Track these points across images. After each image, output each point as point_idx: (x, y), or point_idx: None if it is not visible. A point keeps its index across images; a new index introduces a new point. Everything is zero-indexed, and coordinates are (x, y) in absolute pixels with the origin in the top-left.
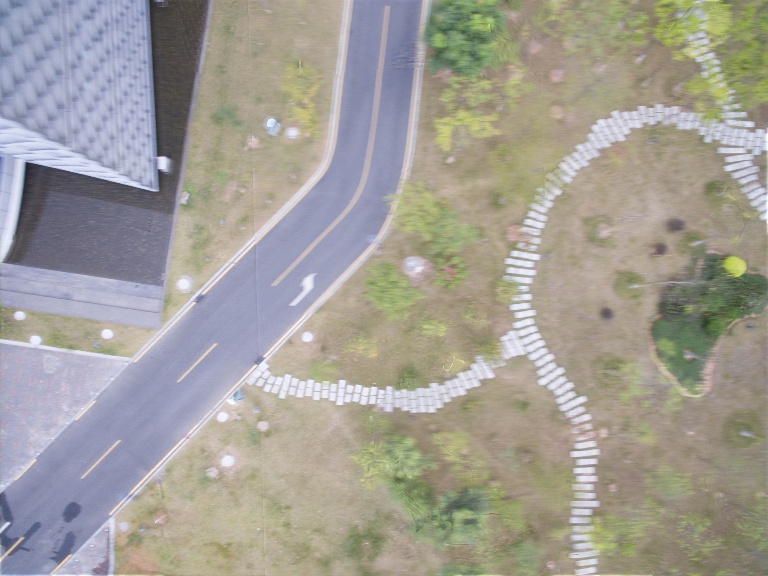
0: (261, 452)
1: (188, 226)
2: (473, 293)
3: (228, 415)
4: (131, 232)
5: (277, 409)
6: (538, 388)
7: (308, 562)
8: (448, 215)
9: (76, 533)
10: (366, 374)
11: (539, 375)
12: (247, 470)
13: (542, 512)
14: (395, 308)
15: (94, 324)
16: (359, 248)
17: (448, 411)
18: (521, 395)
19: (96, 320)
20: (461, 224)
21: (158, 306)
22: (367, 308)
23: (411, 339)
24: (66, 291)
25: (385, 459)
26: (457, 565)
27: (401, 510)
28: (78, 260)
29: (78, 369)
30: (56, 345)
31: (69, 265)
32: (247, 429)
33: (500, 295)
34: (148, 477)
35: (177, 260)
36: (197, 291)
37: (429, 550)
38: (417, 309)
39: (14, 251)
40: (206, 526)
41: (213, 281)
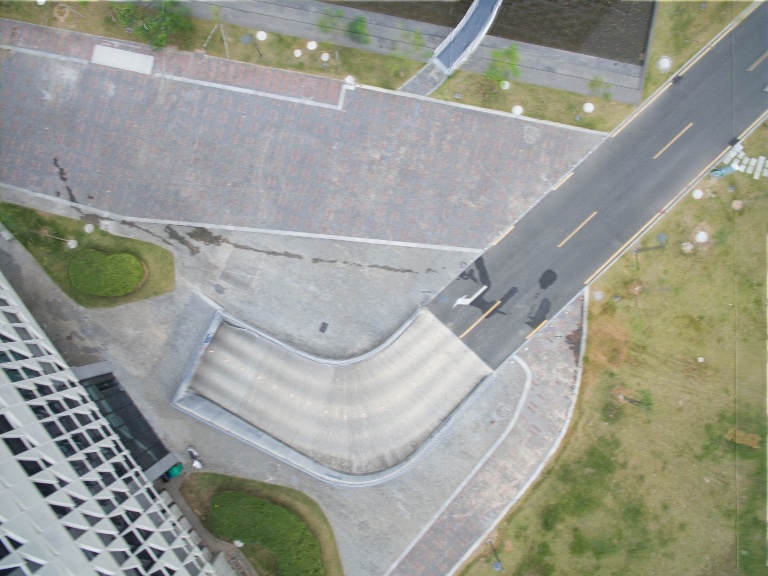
0: (735, 230)
1: (669, 8)
2: None
3: (703, 193)
4: (611, 12)
5: (751, 189)
6: None
7: None
8: None
9: (551, 300)
10: None
11: None
12: (721, 246)
13: None
14: None
15: (577, 97)
16: None
17: None
18: None
19: (579, 93)
20: None
21: (638, 83)
22: None
23: None
24: (549, 64)
25: None
26: None
27: None
28: (558, 36)
29: (557, 141)
30: (537, 116)
31: (549, 41)
32: (722, 207)
33: None
34: (624, 248)
35: (658, 40)
36: (675, 71)
37: None
38: None
39: (496, 24)
40: (679, 299)
41: (690, 63)
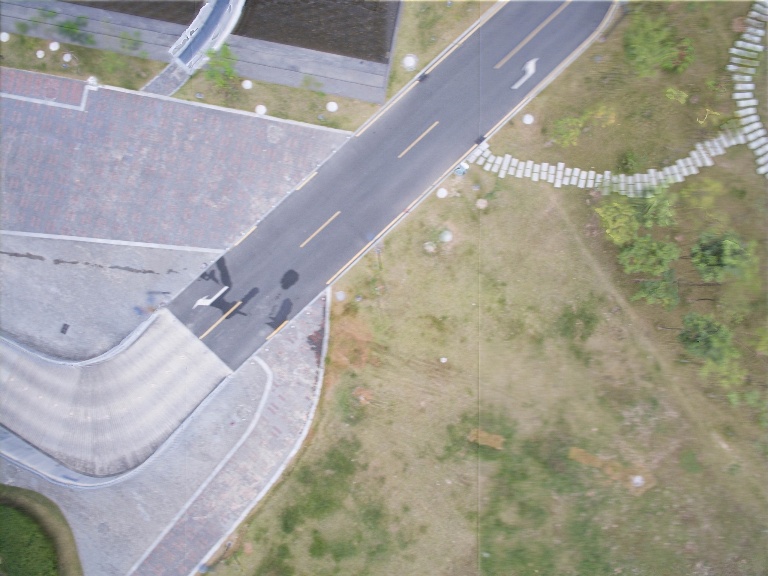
0: (479, 229)
1: (415, 6)
2: (695, 81)
3: (448, 191)
4: (357, 10)
5: (496, 188)
6: (756, 177)
7: (522, 338)
8: (673, 4)
9: (293, 300)
10: (585, 158)
11: (758, 164)
12: (465, 246)
13: (756, 300)
14: (616, 94)
15: (320, 96)
16: (581, 35)
17: (666, 196)
18: (739, 184)
19: (322, 92)
20: (685, 14)
21: (383, 82)
22: (588, 93)
23: (631, 125)
24: (293, 63)
25: (631, 212)
26: (669, 349)
27: (615, 293)
28: (304, 35)
29: (301, 140)
30: (280, 116)
31: (295, 39)
32: (466, 205)
33: (723, 84)
34: (367, 248)
35: (403, 38)
36: (421, 70)
37: (642, 333)
38: (638, 96)
39: (242, 23)
40: (422, 299)
41: (437, 61)
